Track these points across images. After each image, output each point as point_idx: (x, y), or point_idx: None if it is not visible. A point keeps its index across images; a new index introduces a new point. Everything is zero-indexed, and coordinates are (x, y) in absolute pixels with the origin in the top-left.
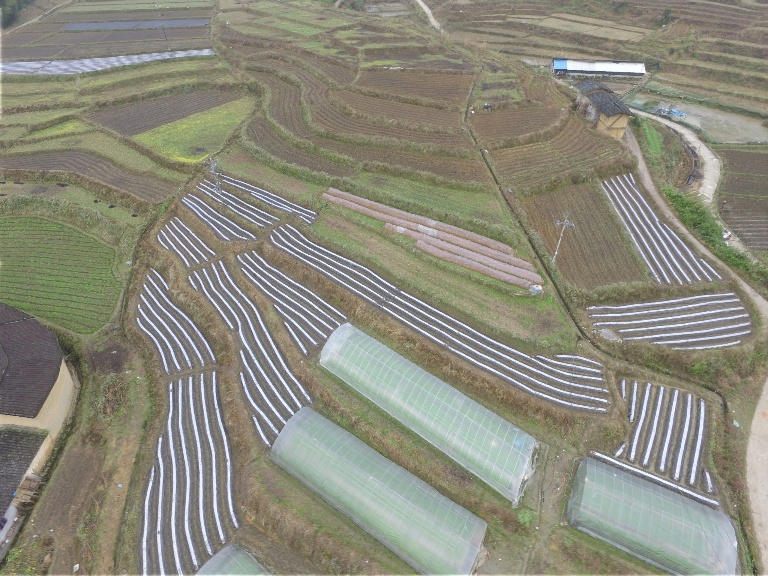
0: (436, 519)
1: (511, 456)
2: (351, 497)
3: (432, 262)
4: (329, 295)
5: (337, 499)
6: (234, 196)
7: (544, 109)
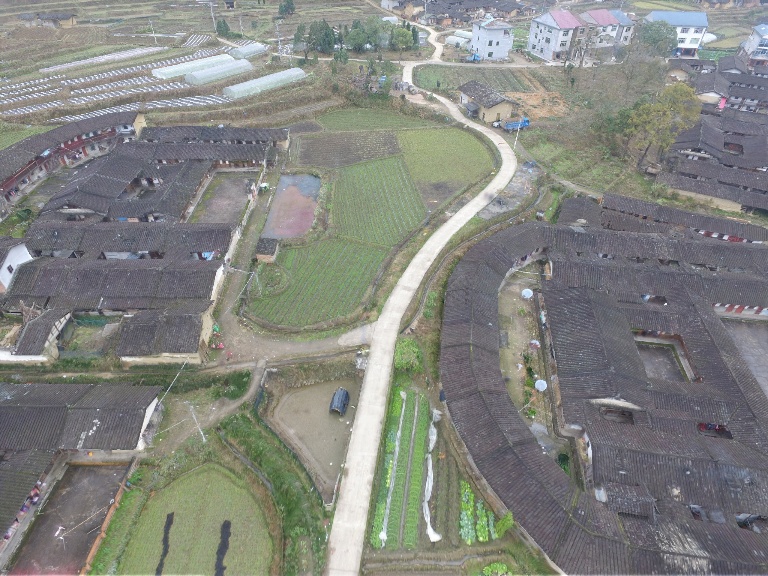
0: (234, 61)
1: (224, 55)
2: (222, 70)
3: (132, 59)
4: (129, 77)
5: (220, 73)
6: (3, 93)
7: (31, 29)
